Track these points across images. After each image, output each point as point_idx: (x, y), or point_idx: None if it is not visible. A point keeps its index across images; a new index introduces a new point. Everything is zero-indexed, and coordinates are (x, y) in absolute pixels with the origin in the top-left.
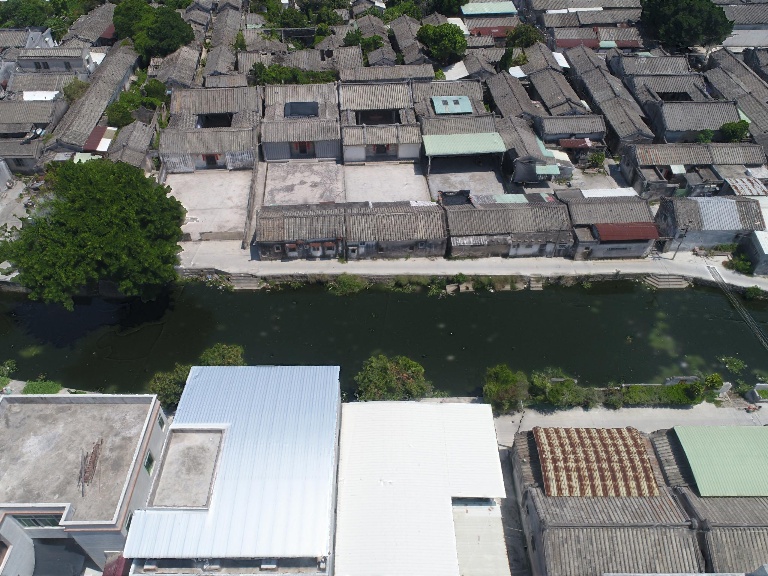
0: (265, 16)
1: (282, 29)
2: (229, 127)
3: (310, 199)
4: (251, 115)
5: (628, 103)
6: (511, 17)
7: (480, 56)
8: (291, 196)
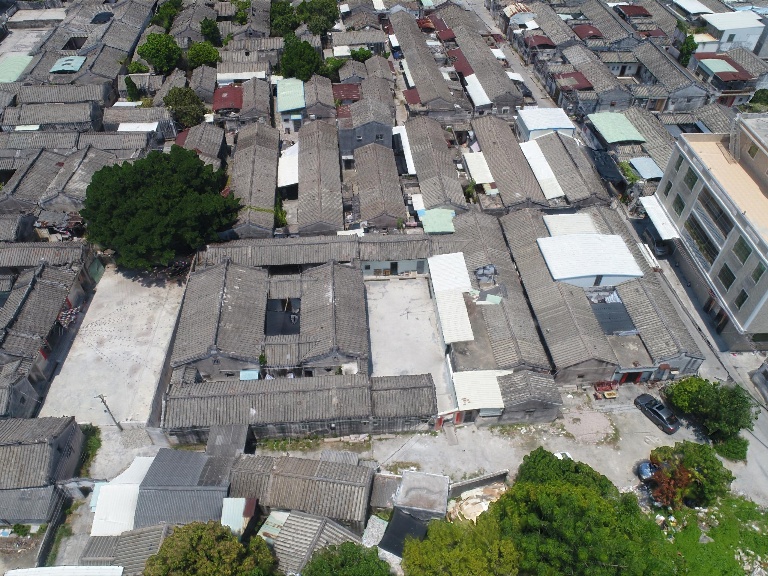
0: (300, 4)
1: (251, 6)
2: (97, 3)
3: (21, 42)
4: (109, 7)
5: (2, 144)
6: (254, 103)
7: (158, 81)
8: (30, 37)
